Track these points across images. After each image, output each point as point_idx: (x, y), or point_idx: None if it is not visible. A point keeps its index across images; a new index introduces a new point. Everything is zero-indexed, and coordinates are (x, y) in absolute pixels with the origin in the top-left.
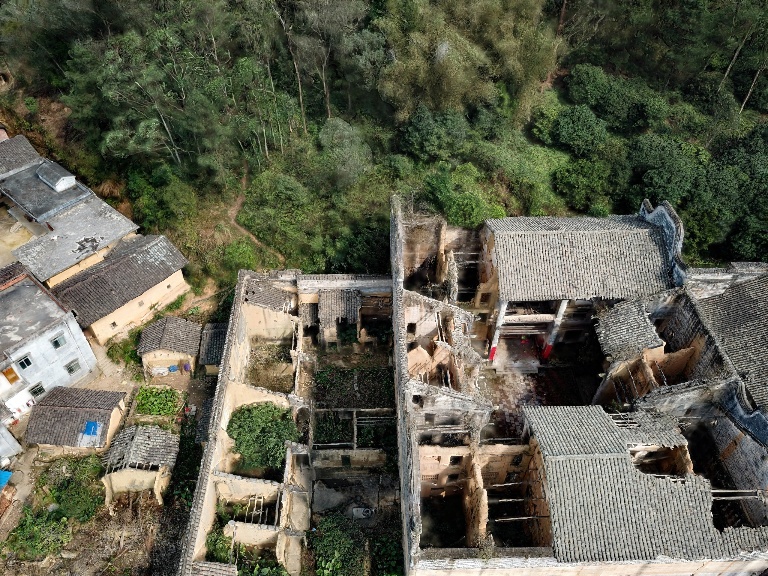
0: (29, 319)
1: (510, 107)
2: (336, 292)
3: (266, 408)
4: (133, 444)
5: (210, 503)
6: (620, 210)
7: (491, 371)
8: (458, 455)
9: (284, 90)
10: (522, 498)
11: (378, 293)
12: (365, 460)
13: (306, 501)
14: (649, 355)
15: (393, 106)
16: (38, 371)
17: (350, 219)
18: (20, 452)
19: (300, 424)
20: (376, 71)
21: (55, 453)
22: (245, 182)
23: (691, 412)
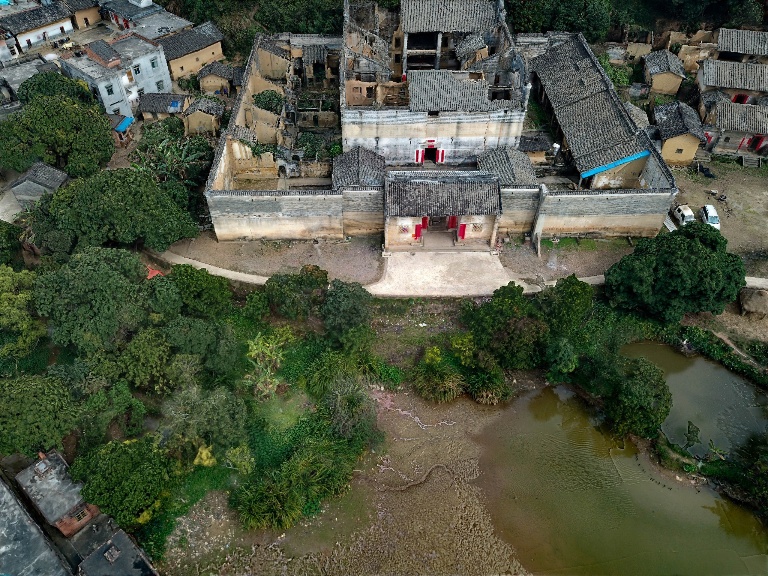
0: (138, 49)
1: None
2: (313, 47)
3: (272, 92)
4: (200, 103)
5: (242, 119)
6: None
7: (404, 95)
8: (370, 87)
9: None
10: None
11: (338, 49)
12: (326, 121)
13: (293, 137)
14: (480, 55)
15: None
16: (143, 80)
17: (323, 12)
18: (134, 122)
19: (290, 100)
20: None
21: (153, 122)
22: None
23: (499, 80)
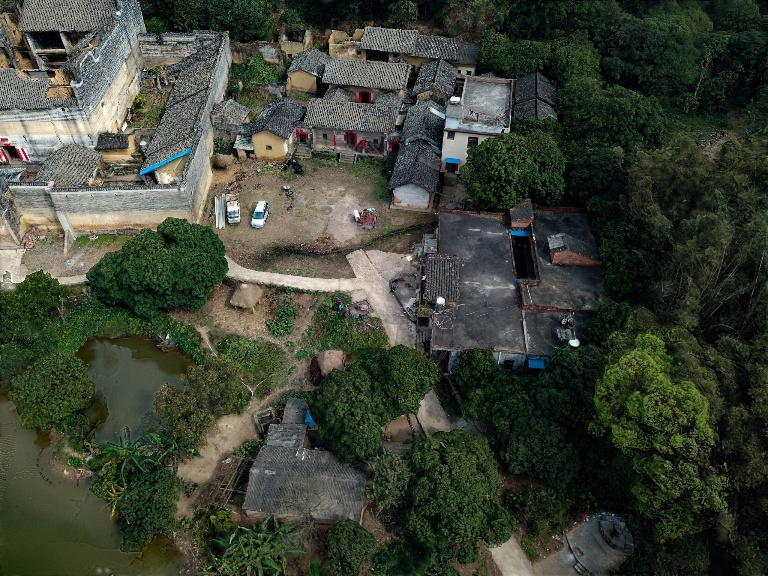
0: None
1: None
2: None
3: None
4: None
5: None
6: (163, 15)
7: None
8: None
9: None
10: None
11: None
12: None
13: None
14: None
15: None
16: None
17: None
18: None
19: None
20: None
21: None
22: None
23: None
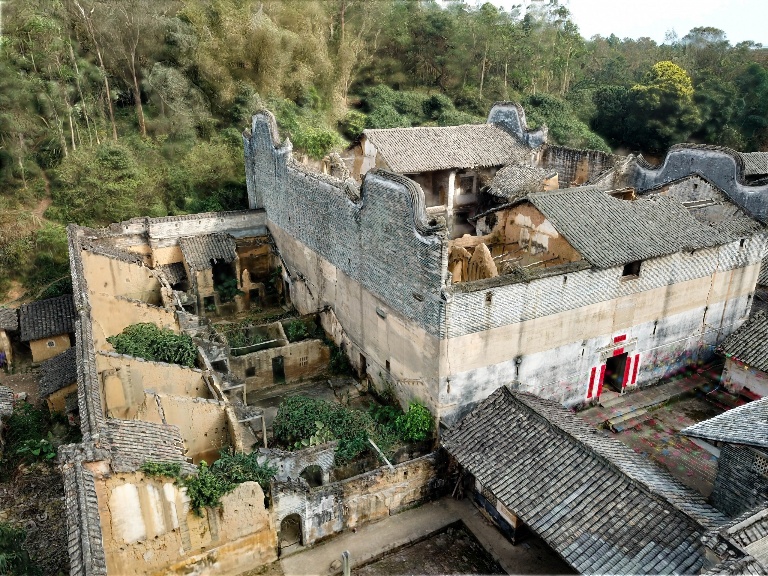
0: None
1: (323, 110)
2: (201, 238)
3: None
4: None
5: None
6: None
7: None
8: None
9: (87, 92)
10: (521, 256)
11: (251, 235)
12: (303, 364)
13: None
14: None
15: (216, 88)
16: None
17: (195, 187)
18: None
19: (203, 336)
20: (192, 54)
21: None
22: (48, 189)
23: None
